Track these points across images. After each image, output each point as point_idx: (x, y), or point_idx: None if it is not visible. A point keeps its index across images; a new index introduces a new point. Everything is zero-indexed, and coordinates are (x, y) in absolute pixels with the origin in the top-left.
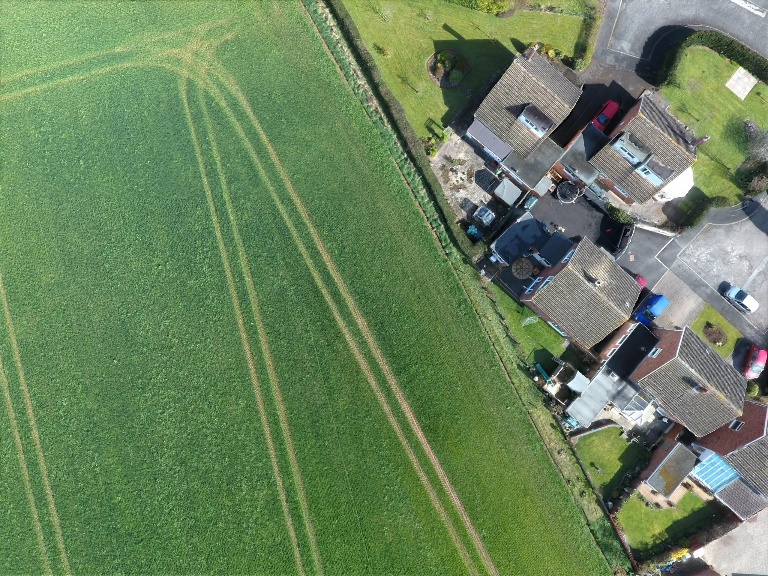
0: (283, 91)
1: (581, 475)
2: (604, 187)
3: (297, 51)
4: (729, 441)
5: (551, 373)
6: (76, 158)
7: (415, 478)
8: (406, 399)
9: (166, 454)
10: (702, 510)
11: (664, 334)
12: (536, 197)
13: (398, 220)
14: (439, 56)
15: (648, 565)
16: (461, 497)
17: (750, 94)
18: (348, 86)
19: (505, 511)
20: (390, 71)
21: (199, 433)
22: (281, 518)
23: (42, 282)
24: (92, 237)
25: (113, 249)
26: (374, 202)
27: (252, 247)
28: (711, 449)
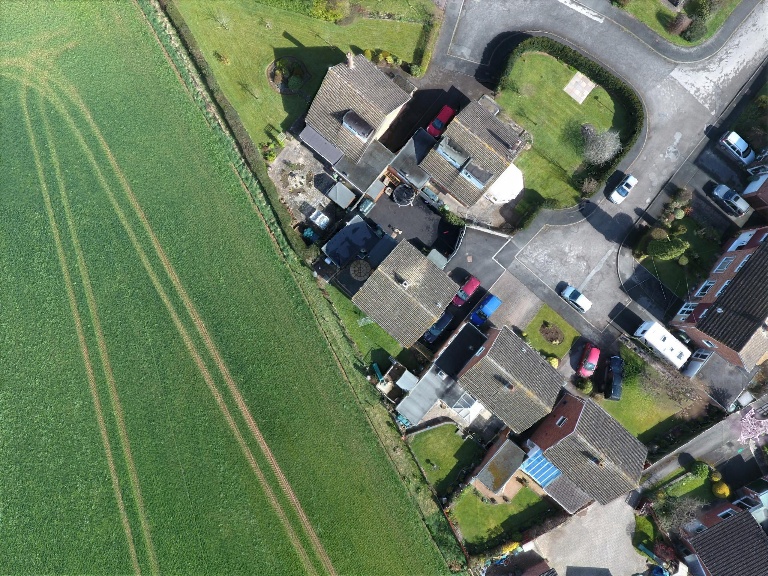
0: (123, 98)
1: (417, 471)
2: (442, 190)
3: (137, 59)
4: (552, 437)
5: (384, 372)
6: None
7: (251, 475)
8: (243, 398)
9: (2, 454)
10: (538, 505)
11: (492, 333)
12: (370, 200)
13: (237, 224)
14: (278, 63)
15: (478, 559)
16: (297, 494)
17: (588, 98)
18: (188, 93)
19: (341, 507)
20: (230, 78)
21: (35, 433)
22: (116, 515)
23: None
24: None
25: None
26: (213, 206)
27: (90, 251)
28: (538, 445)
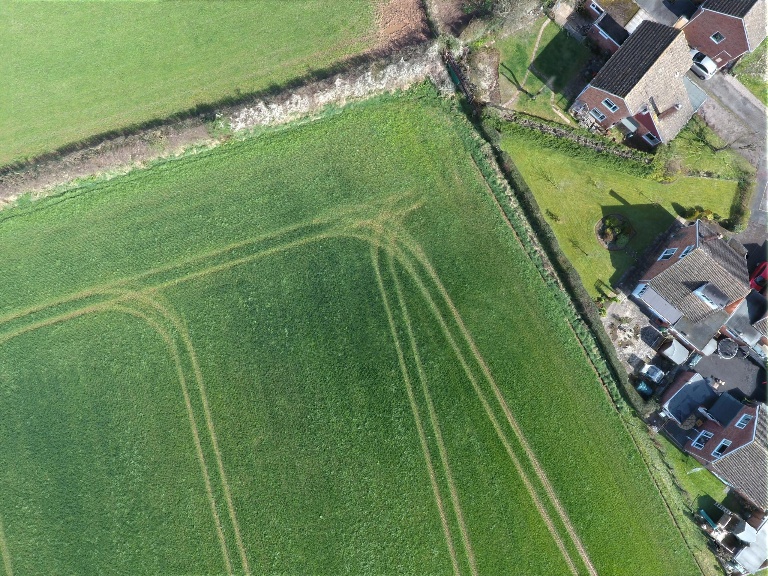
0: (465, 257)
1: None
2: (759, 341)
3: (477, 219)
4: None
5: (717, 521)
6: (281, 326)
7: None
8: (583, 545)
9: None
10: None
11: None
12: (701, 356)
13: (572, 376)
14: (608, 222)
15: None
16: None
17: None
18: (524, 251)
19: None
20: (562, 236)
21: None
22: None
23: (253, 444)
24: (297, 400)
25: (316, 411)
26: (550, 360)
27: (441, 406)
28: None
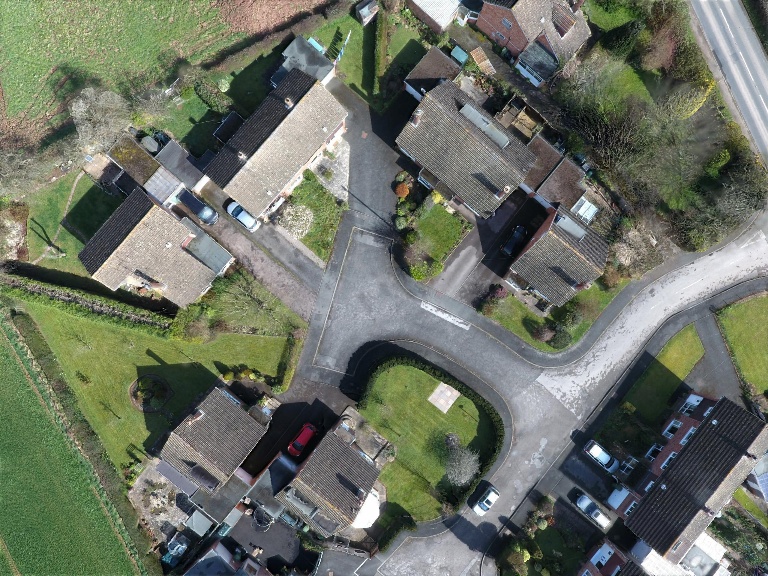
0: None
1: None
2: None
3: None
4: None
5: None
6: None
7: None
8: None
9: None
10: None
11: None
12: (229, 526)
13: (97, 547)
14: (140, 384)
15: None
16: None
17: (452, 407)
18: (50, 416)
19: None
20: (93, 398)
21: None
22: None
23: None
24: None
25: None
26: (73, 530)
27: None
28: None
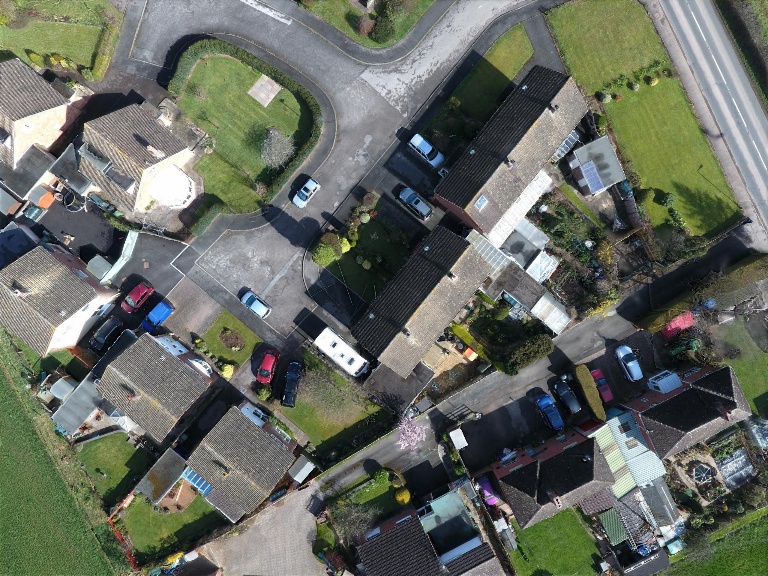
0: None
1: (86, 481)
2: None
3: None
4: None
5: None
6: None
7: None
8: None
9: None
10: (214, 513)
11: None
12: (35, 207)
13: None
14: None
15: (140, 569)
16: None
17: (273, 101)
18: None
19: (6, 517)
20: None
21: None
22: None
23: None
24: None
25: None
26: None
27: None
28: None
